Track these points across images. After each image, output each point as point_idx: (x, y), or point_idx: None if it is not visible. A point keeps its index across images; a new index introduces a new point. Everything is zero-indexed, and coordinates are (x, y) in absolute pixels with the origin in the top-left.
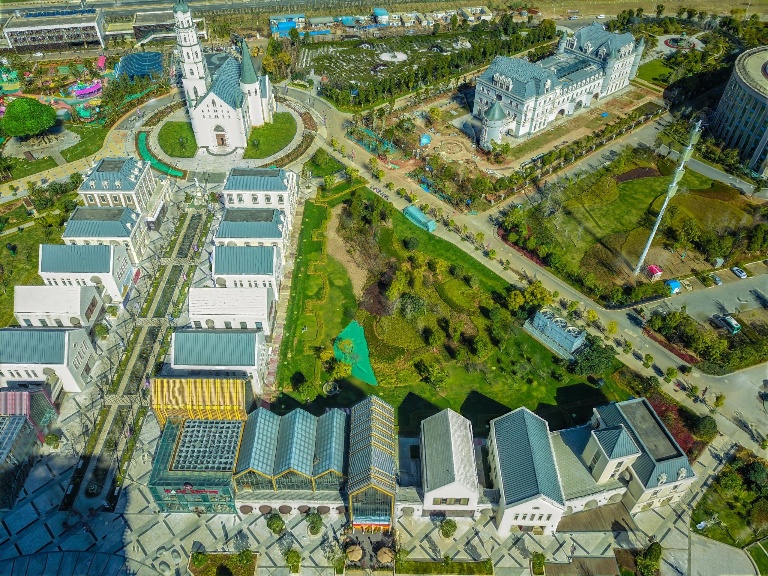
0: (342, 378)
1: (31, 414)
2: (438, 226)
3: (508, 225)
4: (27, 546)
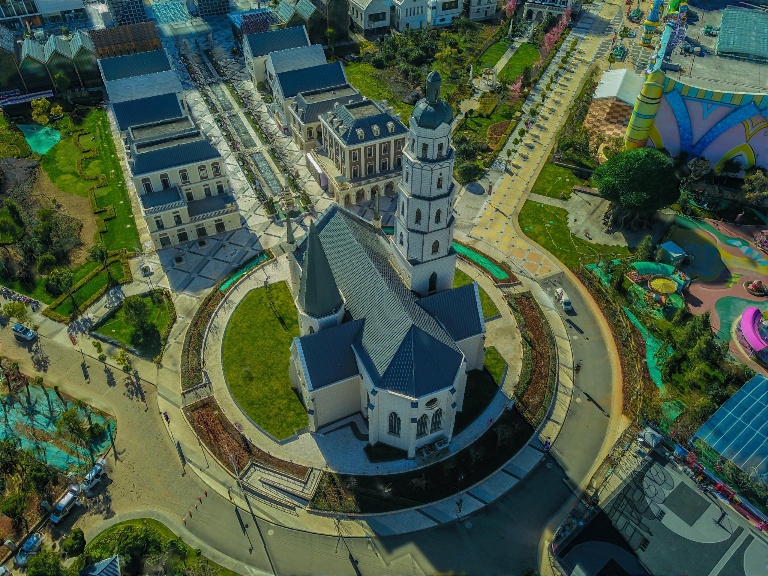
0: None
1: None
2: None
3: None
4: None
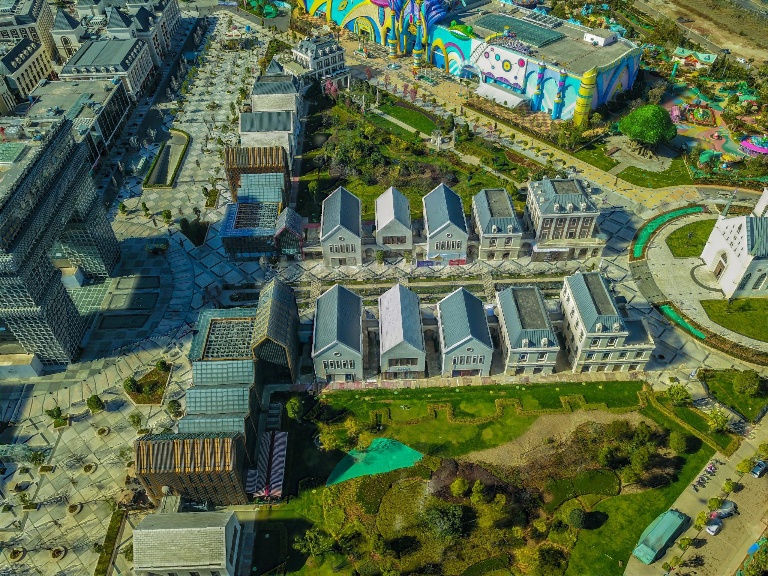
0: (322, 443)
1: (279, 238)
2: (654, 567)
3: None
4: (201, 278)
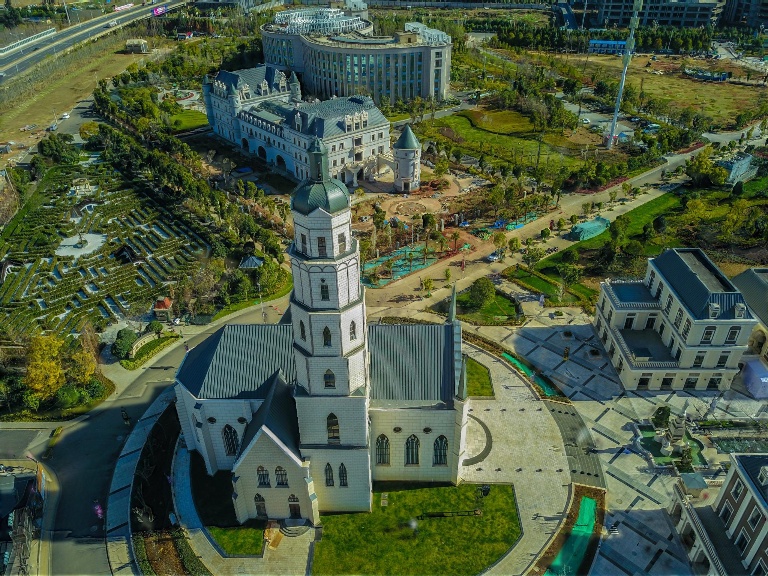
0: None
1: None
2: None
3: (592, 176)
4: None
